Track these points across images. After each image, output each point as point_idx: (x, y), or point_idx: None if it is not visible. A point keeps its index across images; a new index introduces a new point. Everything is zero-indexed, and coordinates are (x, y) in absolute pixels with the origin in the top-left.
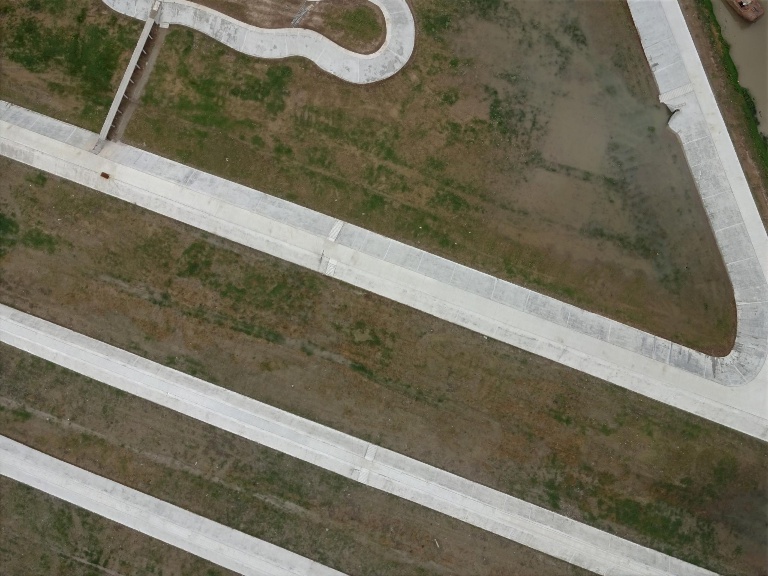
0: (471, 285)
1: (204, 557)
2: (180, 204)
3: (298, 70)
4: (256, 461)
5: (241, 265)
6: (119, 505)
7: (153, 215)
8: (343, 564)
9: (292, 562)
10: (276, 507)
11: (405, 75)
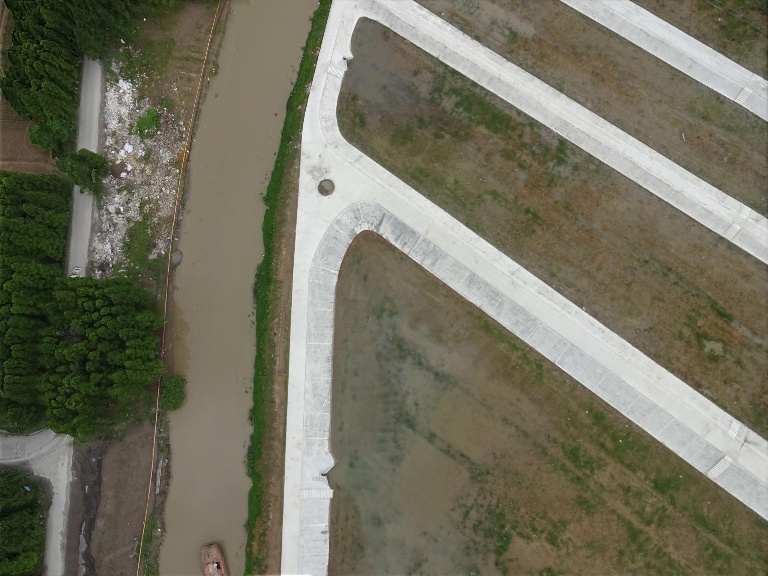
0: (586, 364)
1: None
2: None
3: None
4: None
5: None
6: None
7: None
8: None
9: None
10: None
11: None
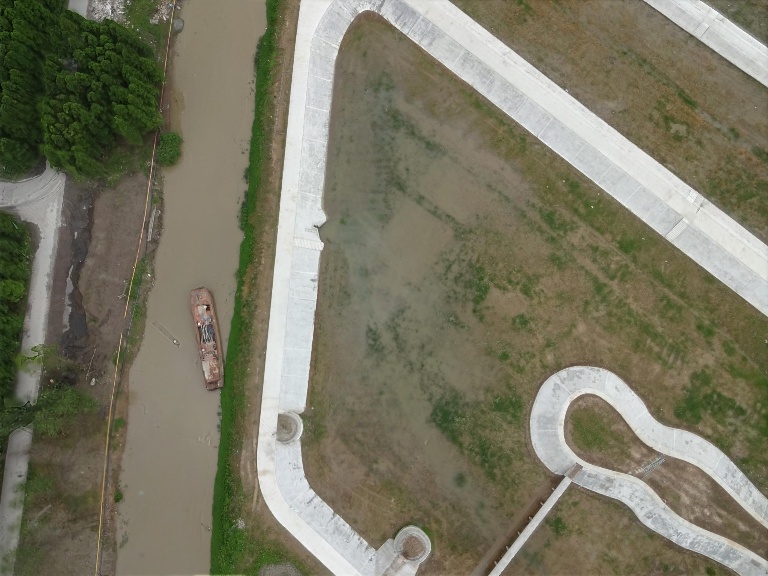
0: (566, 137)
1: None
2: None
3: (667, 410)
4: None
5: None
6: None
7: None
8: None
9: None
10: None
11: (558, 362)
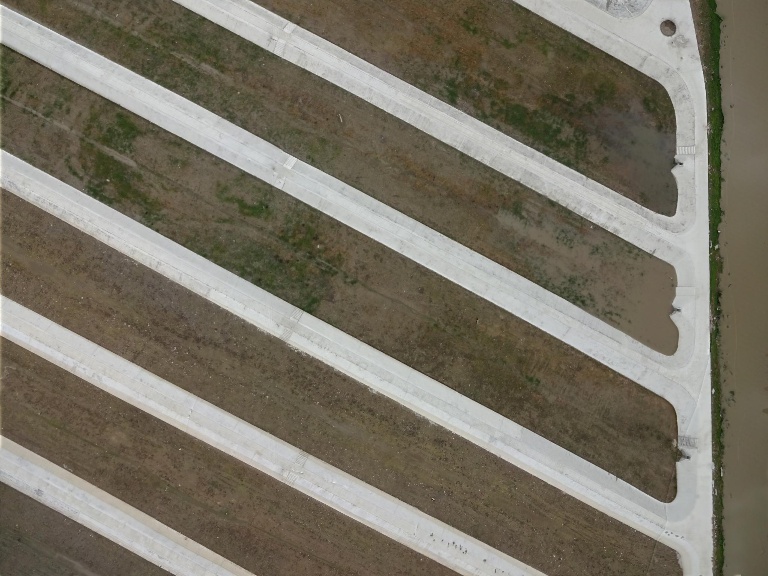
0: None
1: (114, 101)
2: None
3: None
4: (177, 22)
5: None
6: (33, 38)
7: None
8: (250, 124)
9: (201, 114)
10: (192, 66)
11: None
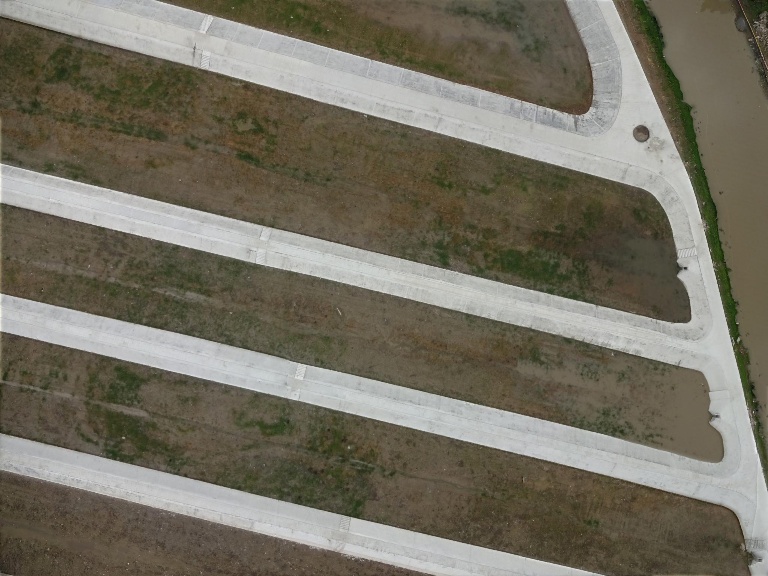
0: (346, 66)
1: (109, 355)
2: (37, 8)
3: None
4: (151, 257)
5: (112, 67)
6: (11, 315)
7: (10, 23)
8: (250, 342)
9: (199, 346)
10: (177, 298)
11: None
